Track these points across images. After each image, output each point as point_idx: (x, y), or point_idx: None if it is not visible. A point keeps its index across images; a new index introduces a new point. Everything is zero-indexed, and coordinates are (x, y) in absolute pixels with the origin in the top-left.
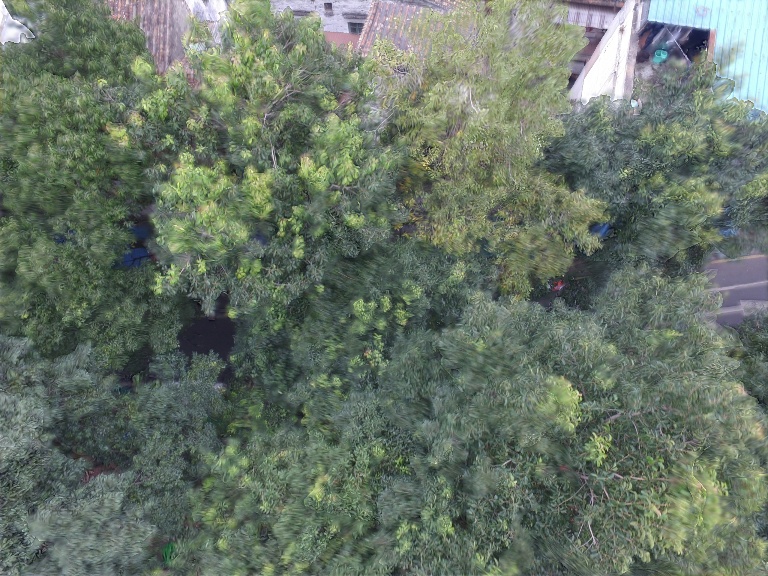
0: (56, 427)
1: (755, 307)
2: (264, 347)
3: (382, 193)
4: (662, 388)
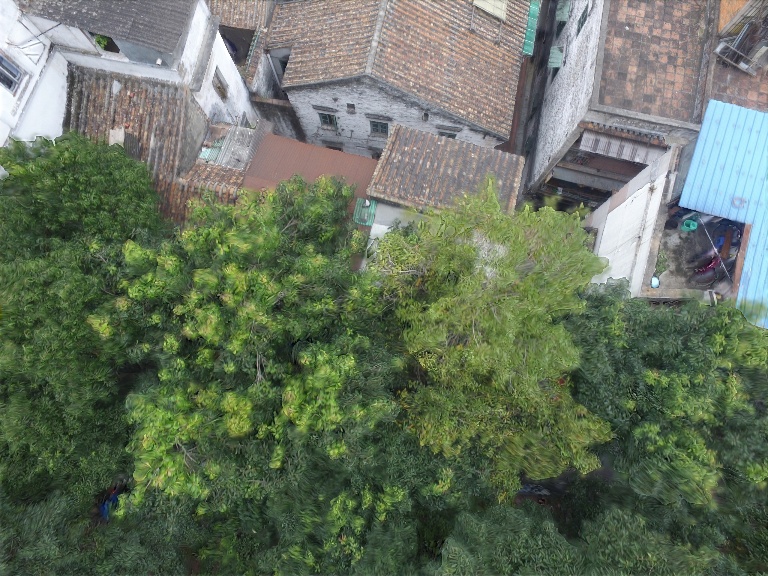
0: None
1: None
2: None
3: None
4: None
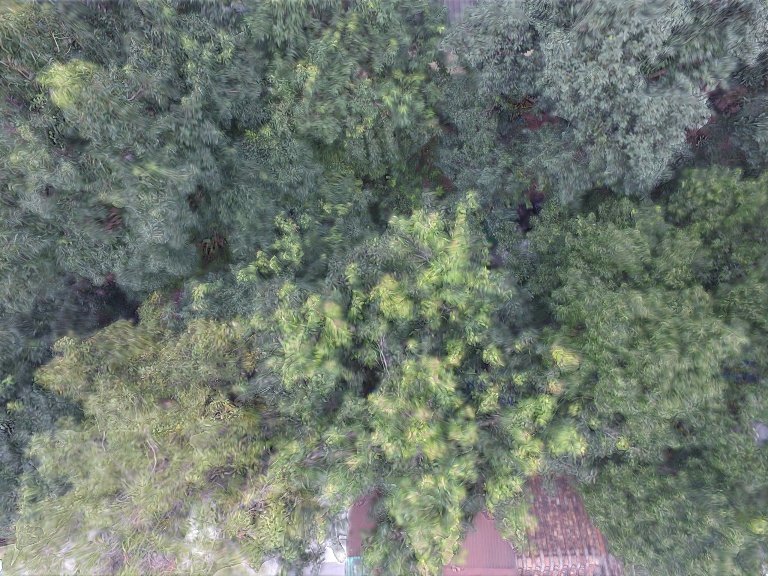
0: None
1: None
2: None
3: None
4: None
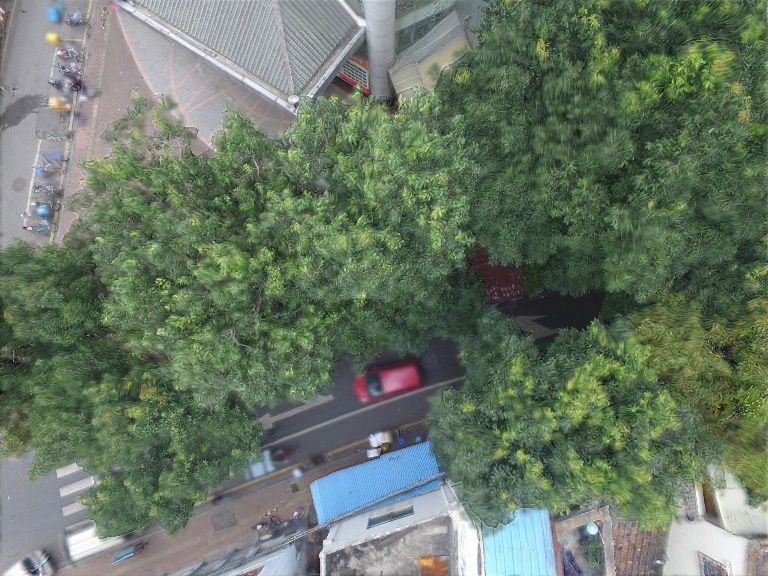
0: None
1: None
2: None
3: None
4: None
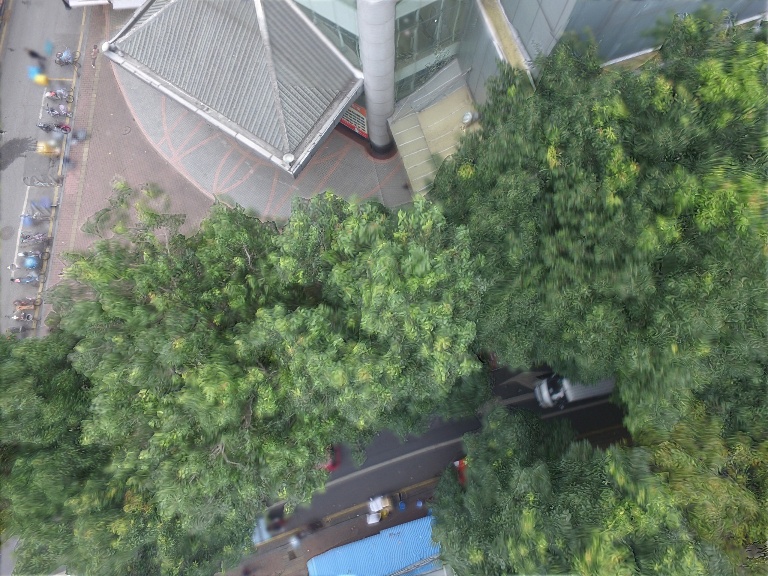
0: None
1: None
2: None
3: None
4: None
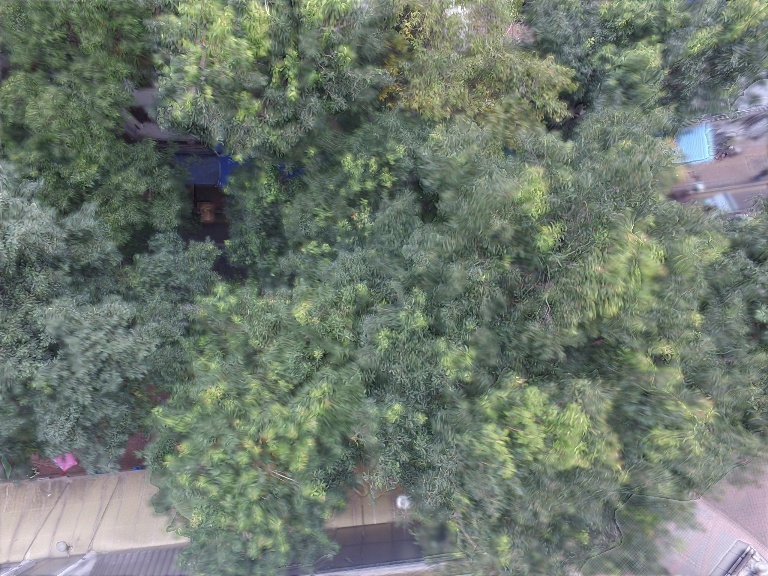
0: (63, 280)
1: (718, 205)
2: (258, 227)
3: (367, 52)
4: (607, 158)
